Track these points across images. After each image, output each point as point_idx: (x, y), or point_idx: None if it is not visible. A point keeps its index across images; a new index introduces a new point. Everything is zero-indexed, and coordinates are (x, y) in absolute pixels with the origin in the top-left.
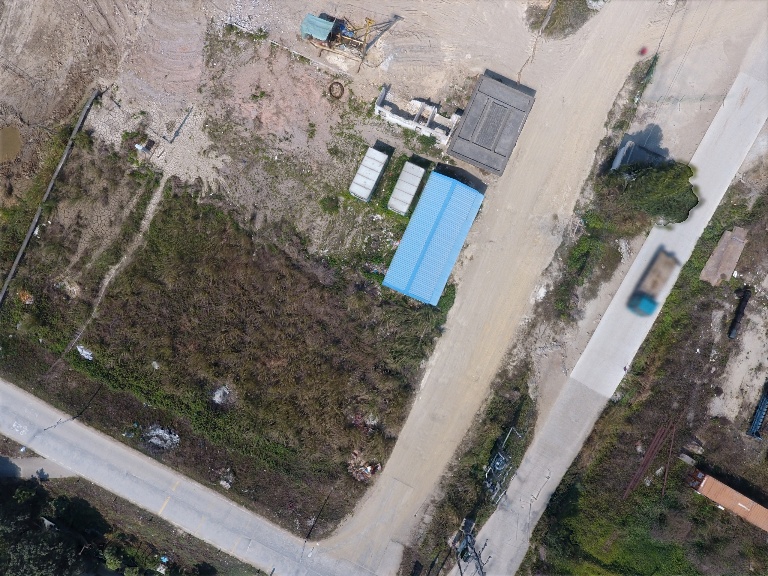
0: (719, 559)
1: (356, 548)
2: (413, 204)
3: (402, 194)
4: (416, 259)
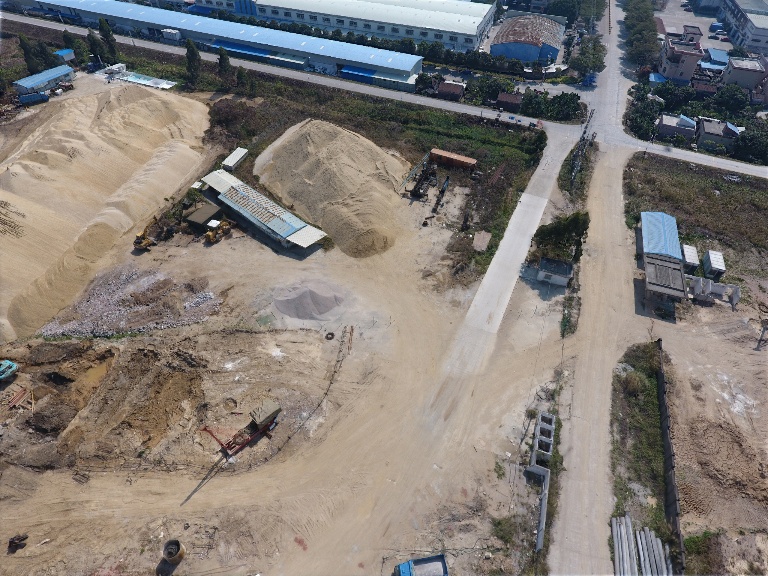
0: (457, 146)
1: (621, 150)
2: (682, 247)
3: (691, 251)
4: (666, 224)
